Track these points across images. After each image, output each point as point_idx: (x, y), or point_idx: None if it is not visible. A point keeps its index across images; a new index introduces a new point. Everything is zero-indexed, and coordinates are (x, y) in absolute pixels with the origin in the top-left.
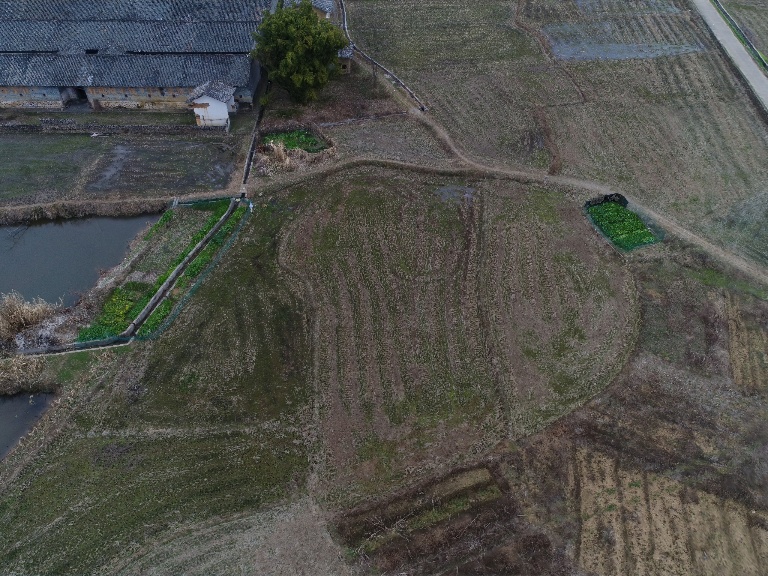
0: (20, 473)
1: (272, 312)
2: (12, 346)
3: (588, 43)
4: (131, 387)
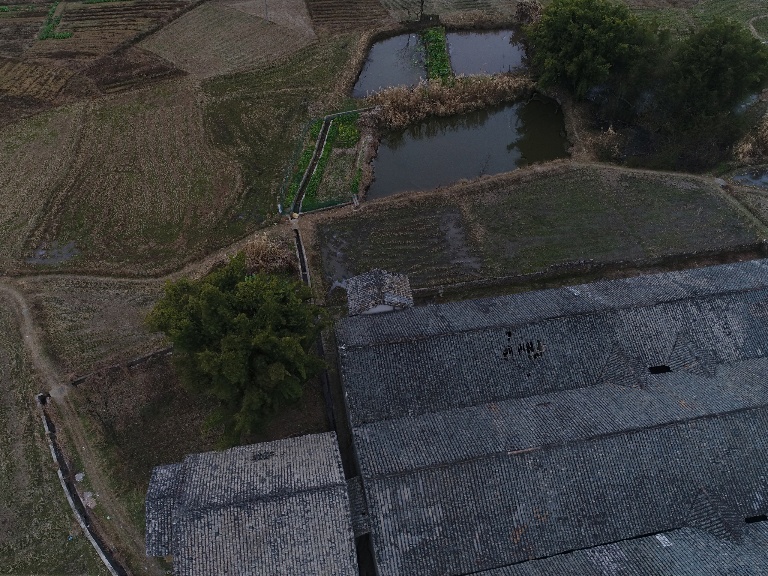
0: None
1: None
2: None
3: None
4: None
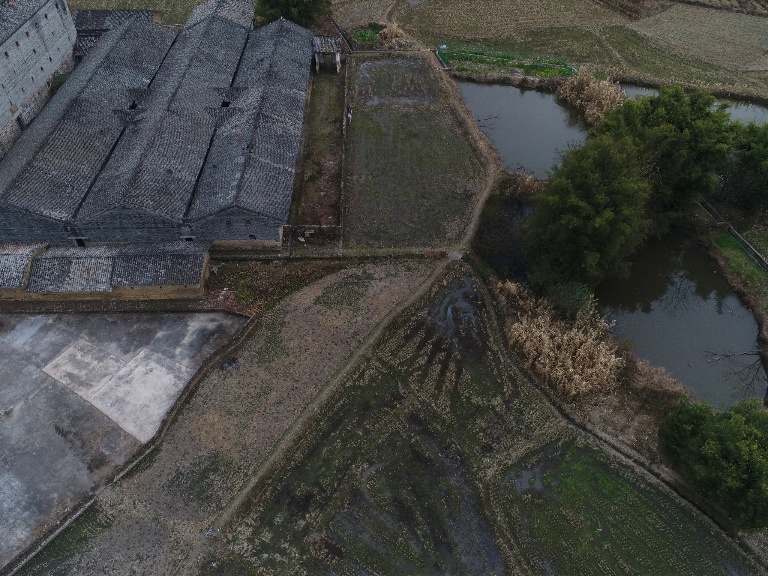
0: None
1: None
2: None
3: None
4: None
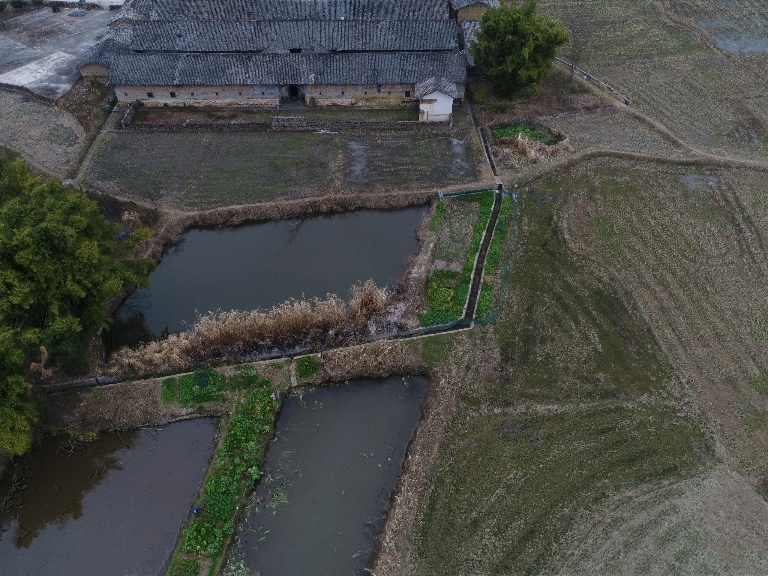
0: (439, 449)
1: (590, 296)
2: (366, 332)
3: (748, 38)
4: (495, 368)
